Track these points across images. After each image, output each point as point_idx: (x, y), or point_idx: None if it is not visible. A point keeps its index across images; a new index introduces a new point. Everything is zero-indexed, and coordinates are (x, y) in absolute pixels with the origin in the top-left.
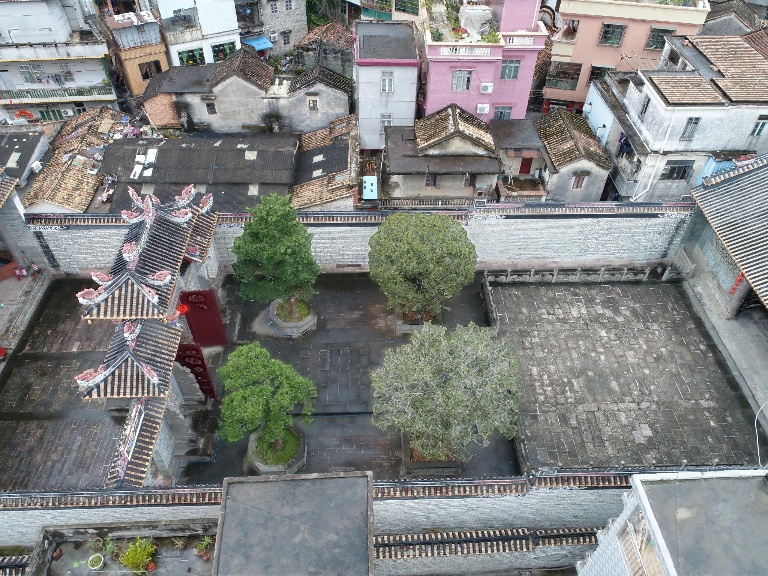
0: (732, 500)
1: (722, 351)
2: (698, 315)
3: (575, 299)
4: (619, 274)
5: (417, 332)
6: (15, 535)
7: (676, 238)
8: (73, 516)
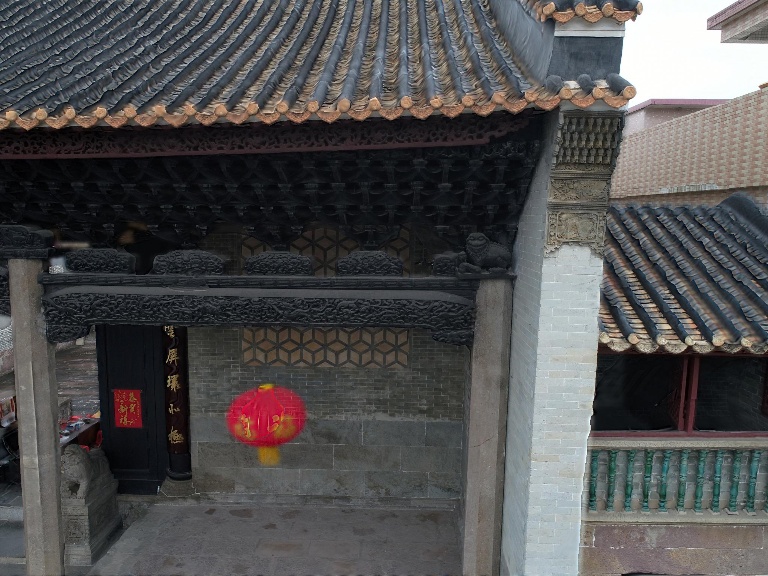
0: None
1: None
2: None
3: None
4: None
5: None
6: None
7: None
8: None
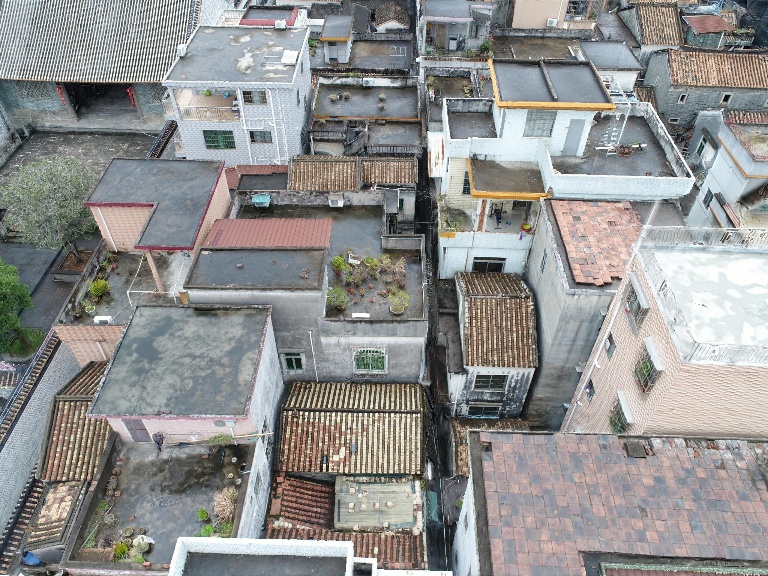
0: (184, 66)
1: (97, 131)
2: (66, 132)
3: (11, 175)
4: (8, 148)
5: (5, 196)
6: (6, 505)
7: (2, 112)
8: (21, 432)
